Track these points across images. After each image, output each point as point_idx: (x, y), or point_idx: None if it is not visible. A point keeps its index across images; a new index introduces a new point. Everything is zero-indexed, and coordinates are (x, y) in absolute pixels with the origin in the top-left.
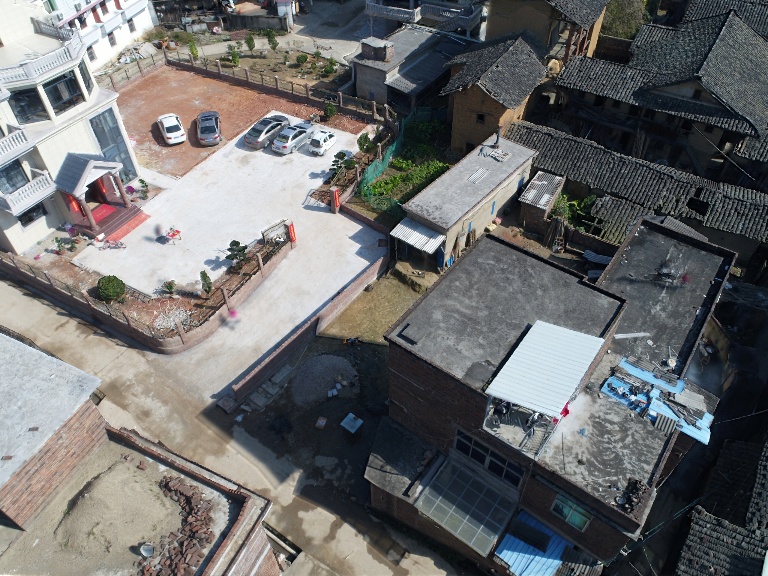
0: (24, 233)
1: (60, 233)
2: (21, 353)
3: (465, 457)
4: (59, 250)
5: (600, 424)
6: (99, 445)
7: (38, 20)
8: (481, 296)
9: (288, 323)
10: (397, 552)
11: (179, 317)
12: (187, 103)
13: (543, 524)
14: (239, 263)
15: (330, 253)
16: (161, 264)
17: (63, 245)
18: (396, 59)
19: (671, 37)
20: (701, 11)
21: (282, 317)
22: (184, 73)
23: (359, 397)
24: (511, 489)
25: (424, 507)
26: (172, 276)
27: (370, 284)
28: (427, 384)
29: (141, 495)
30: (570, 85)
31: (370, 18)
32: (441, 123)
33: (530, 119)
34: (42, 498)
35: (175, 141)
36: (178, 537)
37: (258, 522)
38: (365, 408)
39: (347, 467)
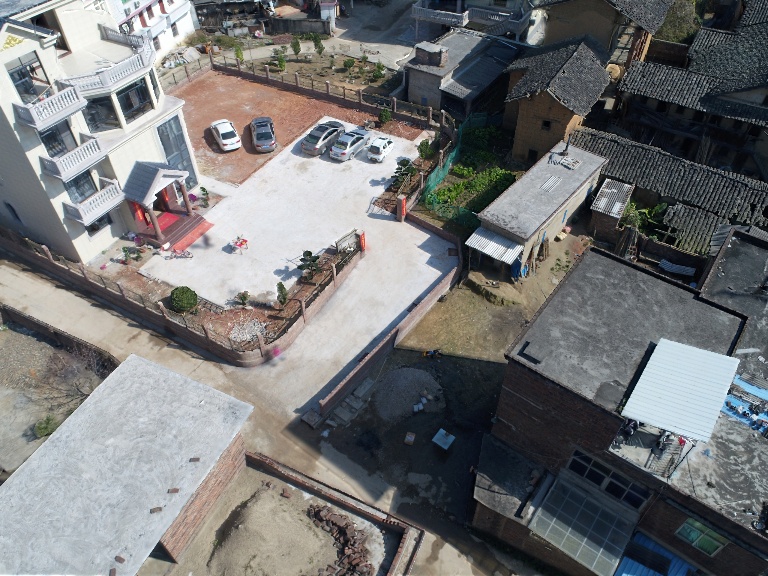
0: (90, 242)
1: (124, 242)
2: (165, 378)
3: (579, 477)
4: (125, 260)
5: (724, 445)
6: (239, 472)
7: (105, 26)
8: (597, 312)
9: (365, 335)
10: (503, 573)
11: (254, 329)
12: (237, 108)
13: (662, 547)
14: (311, 273)
15: (400, 263)
16: (230, 274)
17: (128, 254)
18: (450, 64)
19: (730, 41)
20: (758, 15)
21: (358, 329)
22: (231, 78)
23: (446, 412)
24: (630, 511)
25: (539, 529)
26: (243, 286)
27: (443, 294)
28: (548, 404)
29: (293, 526)
30: (634, 91)
31: (416, 22)
32: (497, 129)
33: (586, 125)
34: (193, 529)
35: (231, 148)
36: (336, 570)
37: (415, 554)
38: (453, 423)
39: (442, 485)
